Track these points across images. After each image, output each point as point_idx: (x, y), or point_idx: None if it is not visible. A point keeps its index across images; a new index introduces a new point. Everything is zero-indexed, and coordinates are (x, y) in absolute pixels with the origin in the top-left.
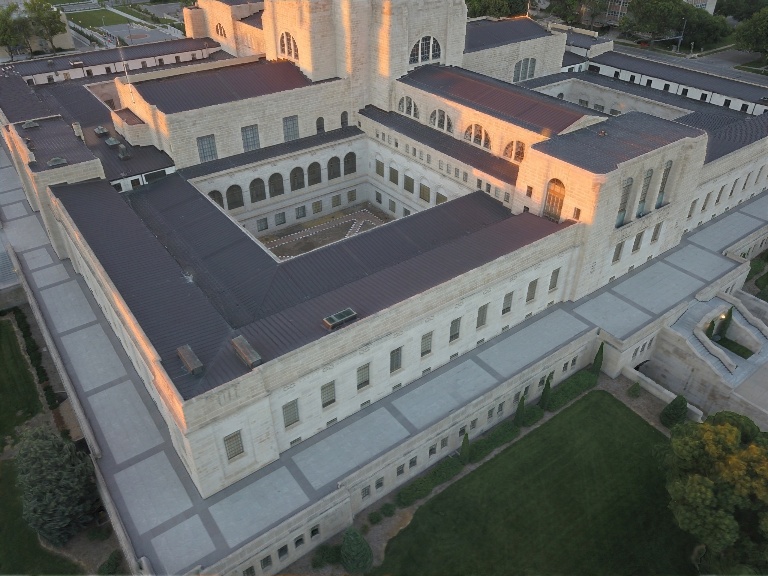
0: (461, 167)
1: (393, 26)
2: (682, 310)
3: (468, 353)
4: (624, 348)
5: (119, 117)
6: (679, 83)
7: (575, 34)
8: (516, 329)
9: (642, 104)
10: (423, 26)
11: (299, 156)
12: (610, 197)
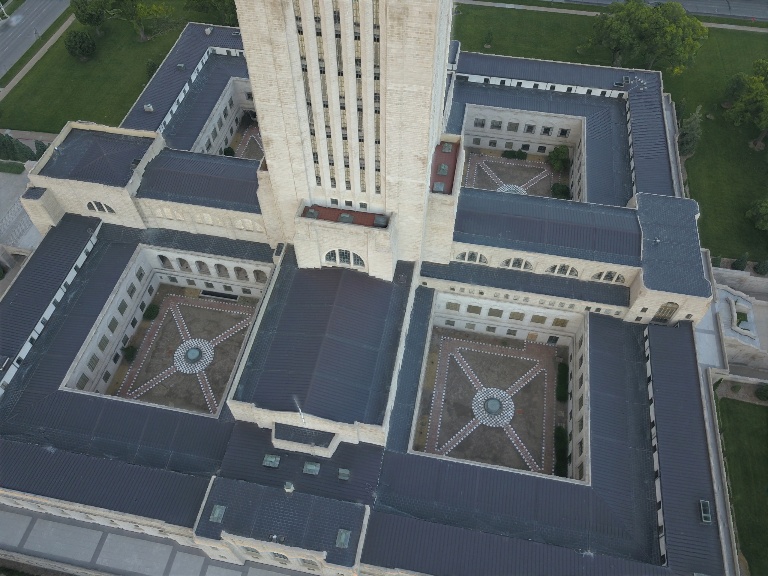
0: (568, 302)
1: (453, 209)
2: None
3: None
4: None
5: (297, 443)
6: (547, 82)
7: None
8: None
9: (539, 117)
10: None
11: None
12: None
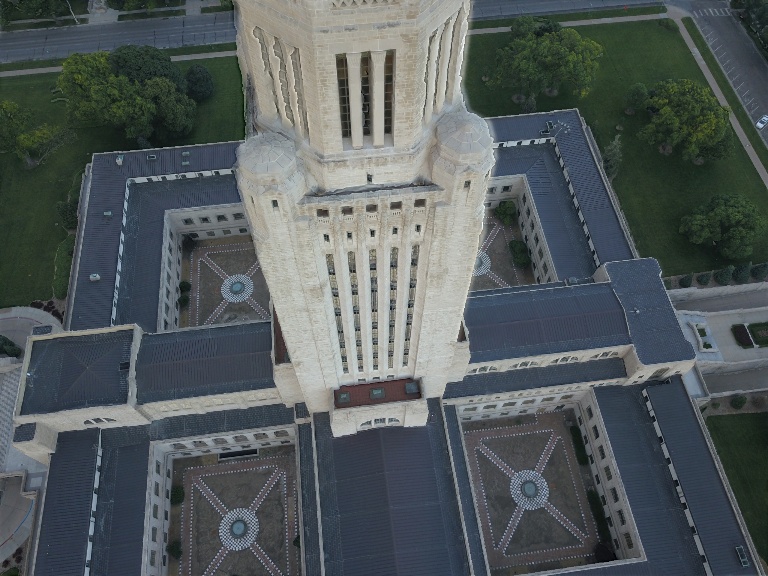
0: (575, 386)
1: None
2: None
3: None
4: None
5: None
6: None
7: None
8: None
9: None
10: None
11: None
12: None
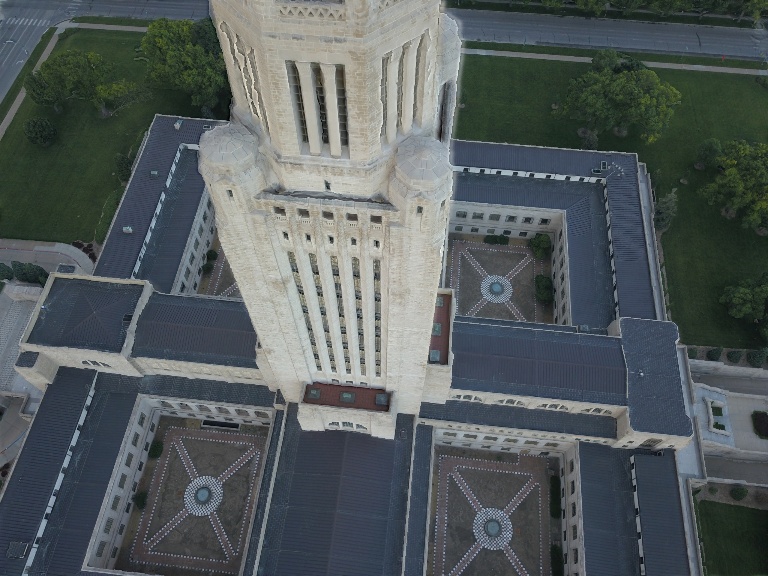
0: None
1: (450, 372)
2: None
3: None
4: None
5: None
6: (526, 171)
7: None
8: None
9: (521, 211)
10: None
11: None
12: None
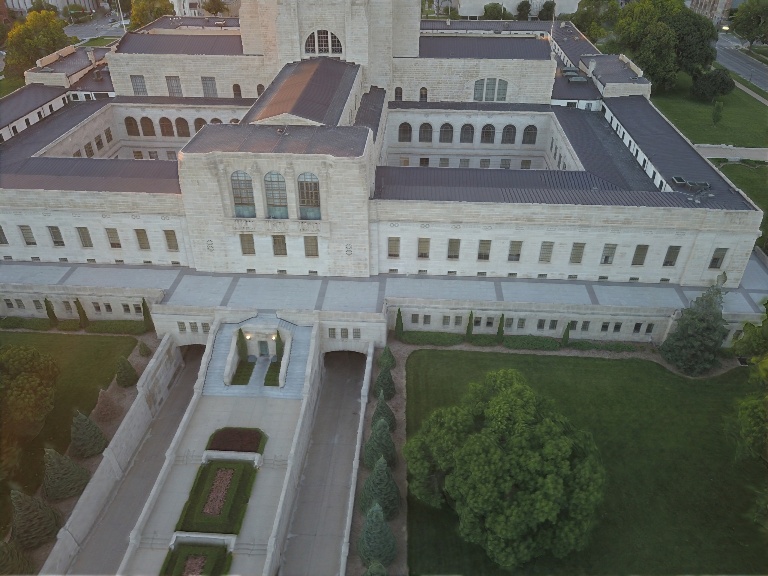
0: None
1: (282, 15)
2: (245, 313)
3: (77, 264)
4: (155, 311)
5: None
6: (635, 141)
7: (627, 70)
8: (129, 267)
9: None
10: (317, 20)
11: (201, 109)
12: (200, 179)
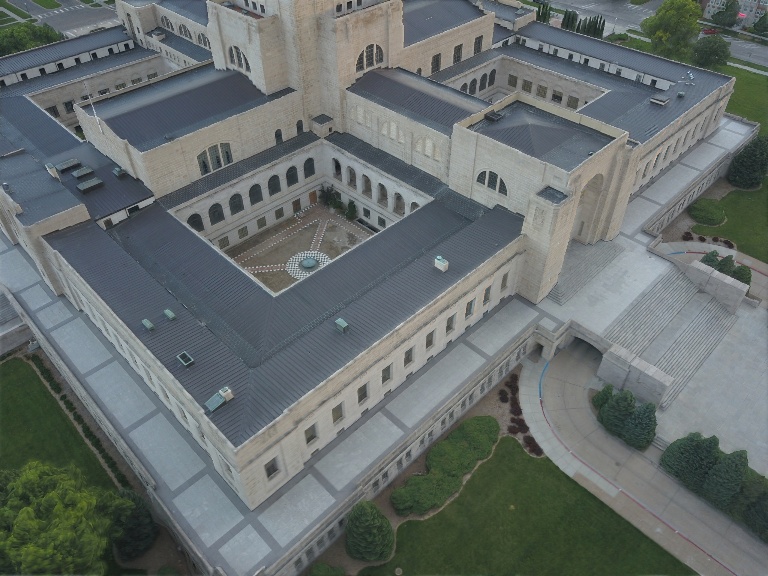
0: None
1: None
2: None
3: None
4: None
5: None
6: None
7: None
8: None
9: None
10: None
11: None
12: None
